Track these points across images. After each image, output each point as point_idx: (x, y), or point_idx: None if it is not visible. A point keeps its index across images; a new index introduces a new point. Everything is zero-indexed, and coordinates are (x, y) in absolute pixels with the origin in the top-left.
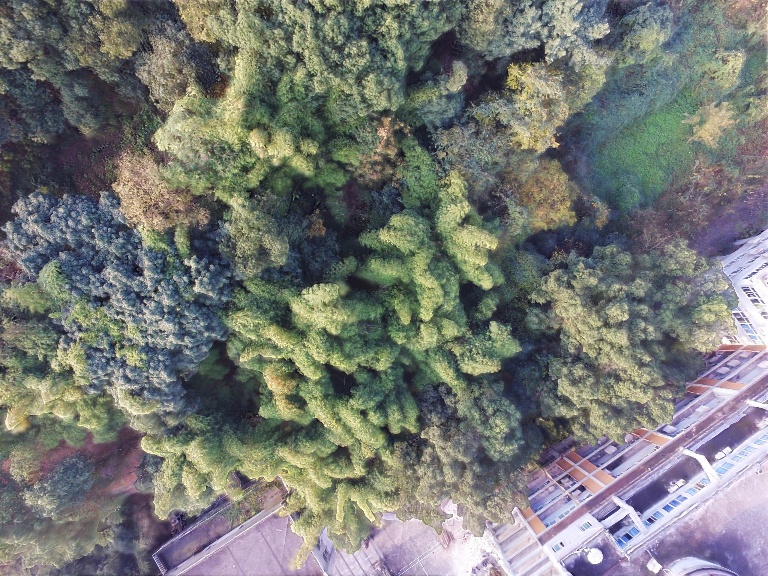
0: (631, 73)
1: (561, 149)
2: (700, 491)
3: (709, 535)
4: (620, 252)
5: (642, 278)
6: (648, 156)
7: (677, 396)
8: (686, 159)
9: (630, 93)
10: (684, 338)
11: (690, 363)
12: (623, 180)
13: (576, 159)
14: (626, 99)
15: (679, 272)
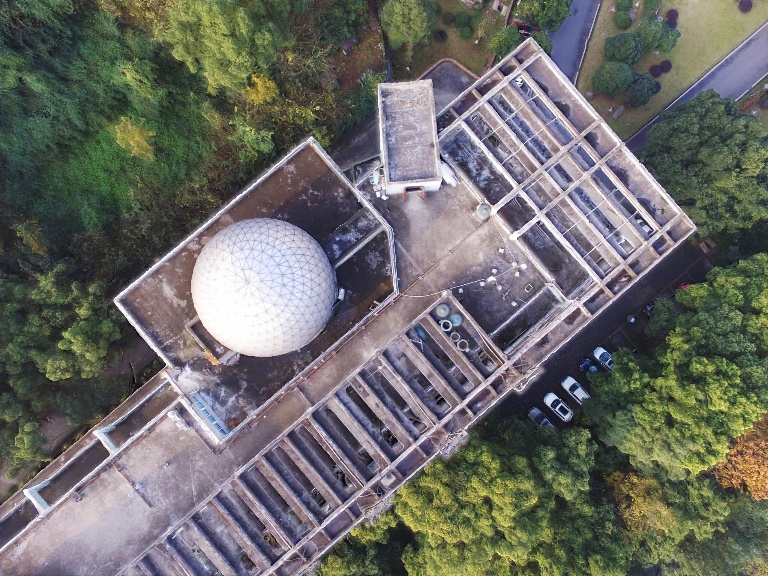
0: (40, 95)
1: (2, 178)
2: (27, 525)
3: (31, 569)
4: (1, 285)
5: (5, 311)
6: (113, 173)
7: (68, 424)
8: (162, 171)
9: (35, 116)
10: (42, 369)
11: (95, 388)
12: (82, 201)
13: (5, 188)
14: (31, 123)
15: (48, 301)
